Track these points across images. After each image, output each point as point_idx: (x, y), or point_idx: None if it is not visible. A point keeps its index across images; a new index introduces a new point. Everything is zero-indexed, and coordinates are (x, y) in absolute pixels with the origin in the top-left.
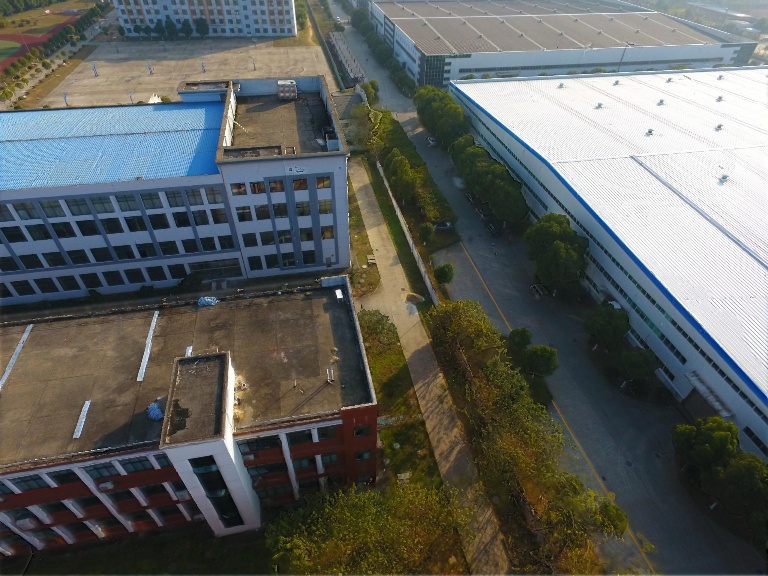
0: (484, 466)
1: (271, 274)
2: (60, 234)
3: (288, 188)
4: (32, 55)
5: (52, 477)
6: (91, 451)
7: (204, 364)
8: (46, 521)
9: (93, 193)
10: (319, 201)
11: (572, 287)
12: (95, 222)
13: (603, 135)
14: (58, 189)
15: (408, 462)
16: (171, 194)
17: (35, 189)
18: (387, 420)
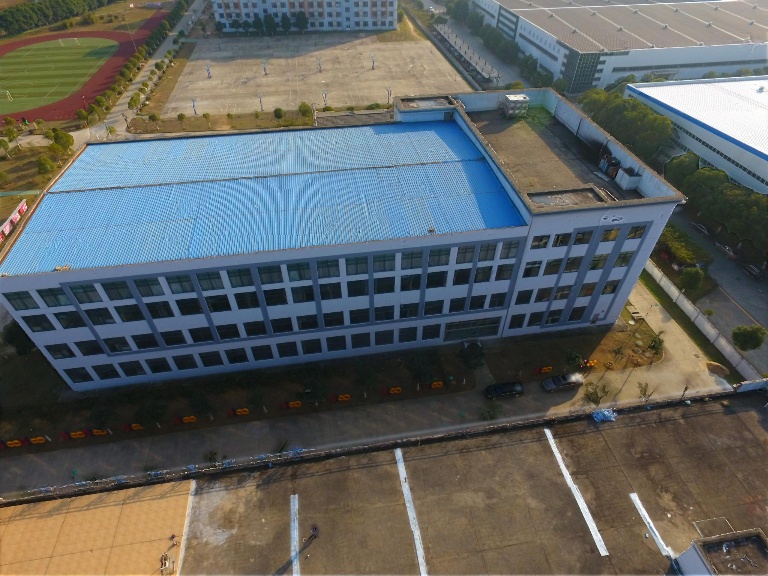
0: None
1: (527, 332)
2: (324, 295)
3: (594, 240)
4: (140, 55)
5: None
6: None
7: (738, 552)
8: None
9: (379, 250)
10: (620, 253)
11: None
12: (367, 282)
13: None
14: (343, 247)
15: None
16: (463, 249)
17: (319, 247)
18: None
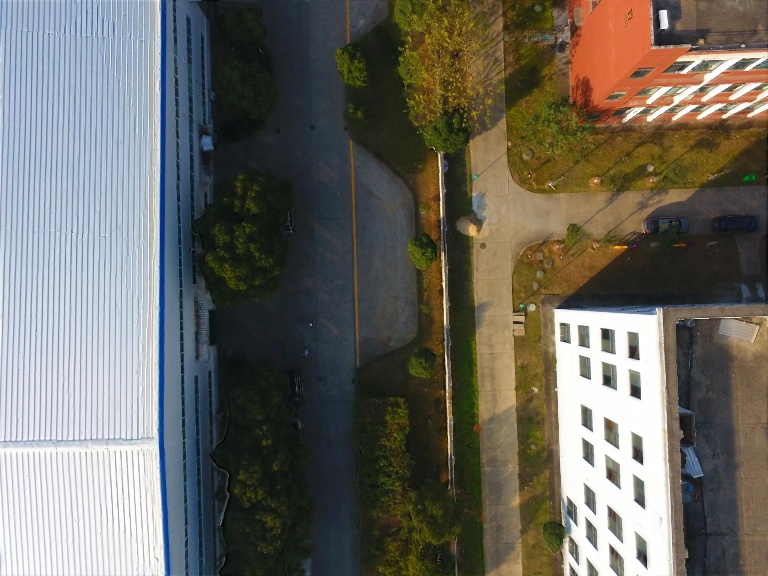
0: None
1: None
2: None
3: None
4: None
5: None
6: None
7: None
8: None
9: None
10: None
11: None
12: None
13: None
14: None
15: None
16: None
17: None
18: (543, 38)
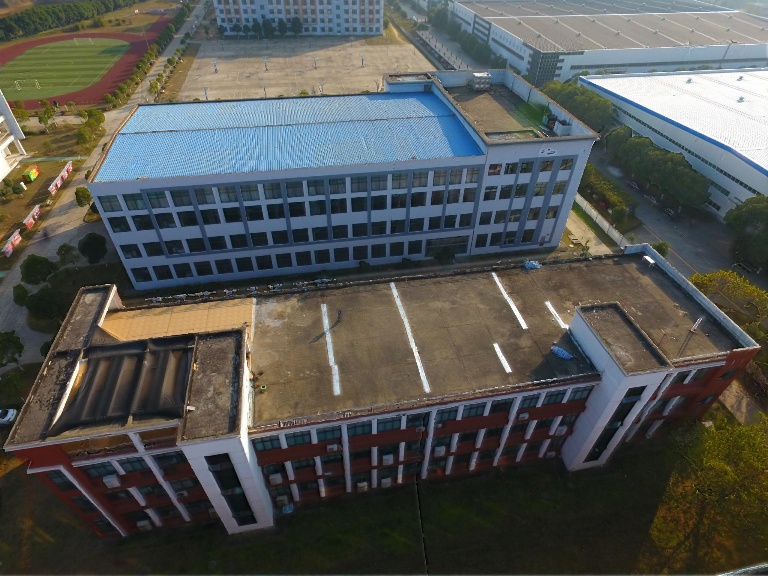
0: None
1: (490, 251)
2: (334, 210)
3: (535, 169)
4: (152, 52)
5: (493, 405)
6: (544, 381)
7: (602, 311)
8: (453, 449)
9: (376, 171)
10: (556, 182)
11: None
12: (366, 199)
13: (765, 126)
14: (349, 167)
15: (706, 413)
16: (438, 173)
17: (331, 167)
18: None
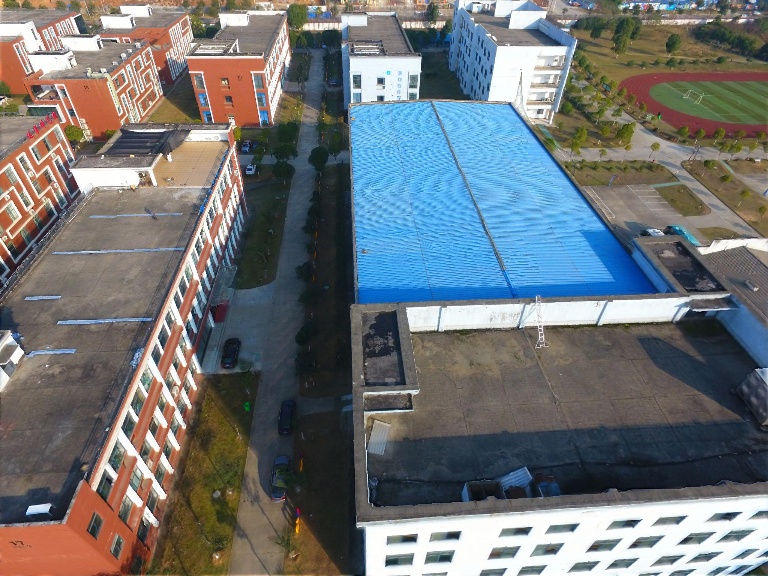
0: None
1: None
2: None
3: None
4: None
5: None
6: None
7: None
8: None
9: None
10: None
11: None
12: None
13: None
14: None
15: None
16: None
17: None
18: None
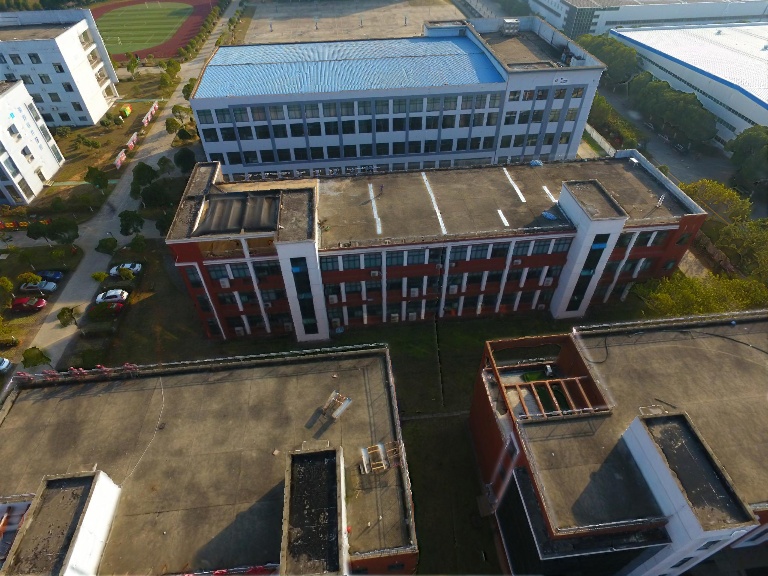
0: (765, 272)
1: None
2: (378, 129)
3: (550, 97)
4: None
5: (493, 249)
6: (532, 228)
7: (583, 185)
8: (464, 289)
9: (414, 95)
10: (568, 109)
11: (764, 191)
12: (405, 120)
13: None
14: (392, 91)
15: None
16: (465, 98)
17: (378, 90)
18: None
